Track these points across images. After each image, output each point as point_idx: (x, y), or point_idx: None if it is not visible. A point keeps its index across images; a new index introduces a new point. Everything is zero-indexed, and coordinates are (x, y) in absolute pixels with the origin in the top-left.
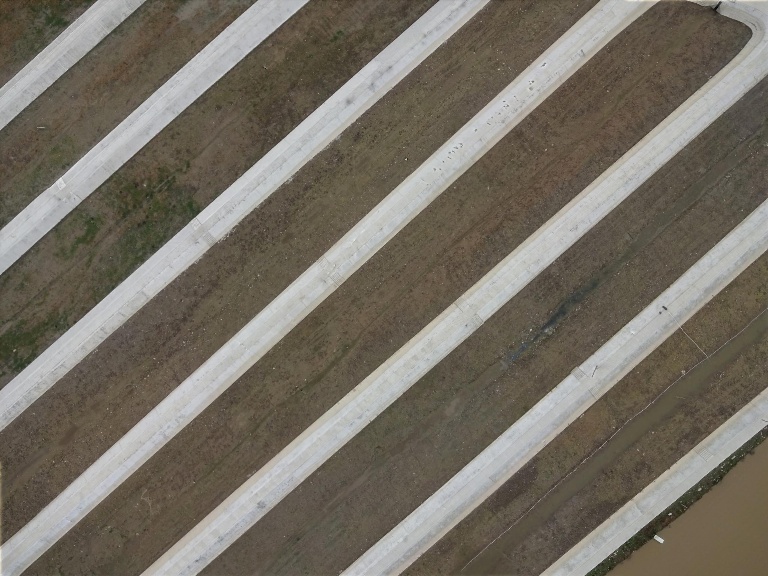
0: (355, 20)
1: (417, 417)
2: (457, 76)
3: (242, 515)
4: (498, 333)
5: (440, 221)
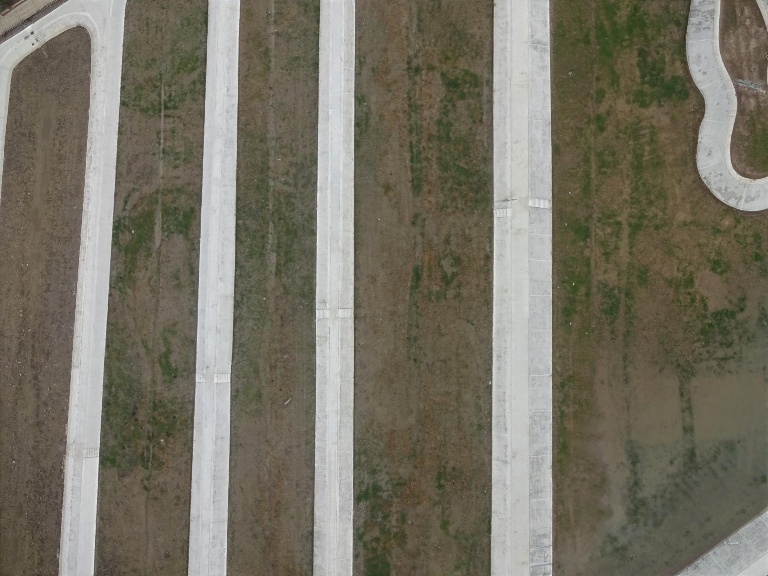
0: None
1: None
2: None
3: None
4: None
5: None
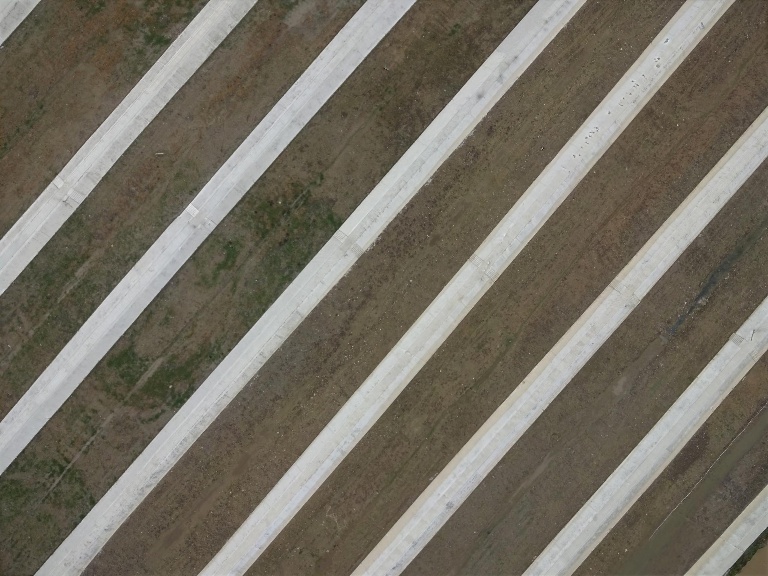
0: (470, 11)
1: (588, 400)
2: (581, 60)
3: (433, 518)
4: (655, 310)
5: (584, 207)
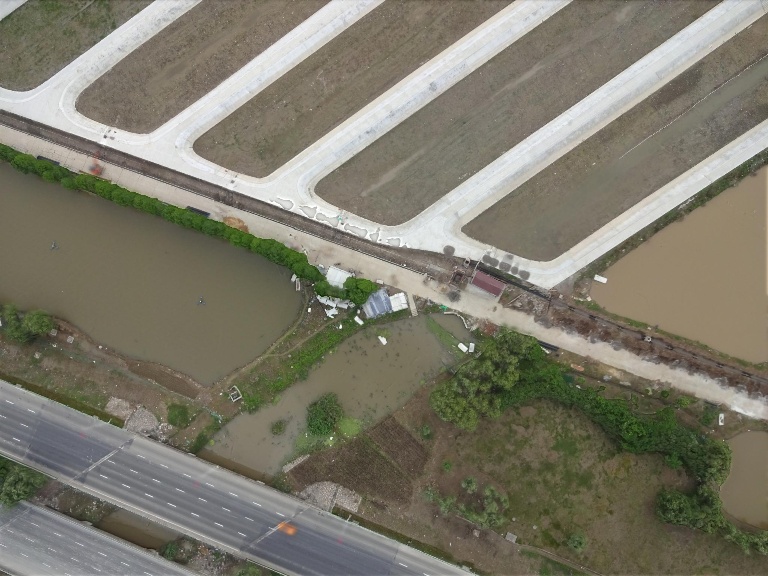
0: None
1: (588, 20)
2: None
3: (415, 93)
4: None
5: None
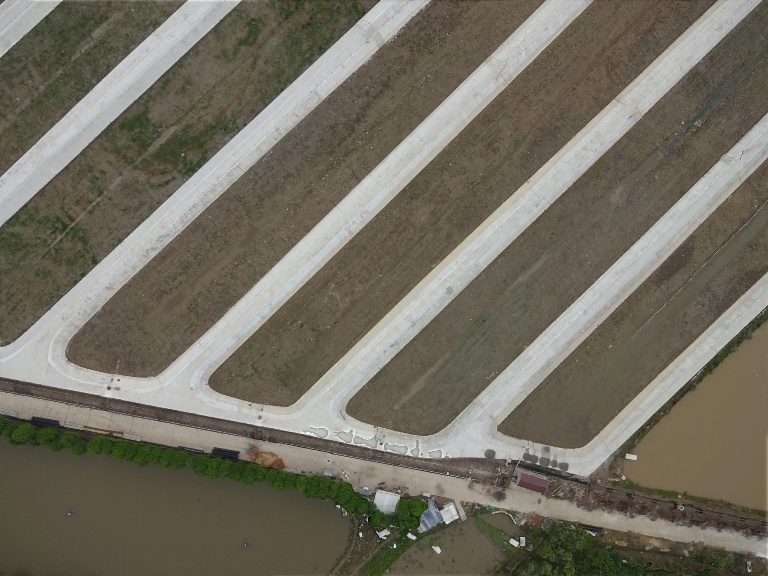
0: None
1: (586, 205)
2: None
3: (433, 300)
4: (655, 126)
5: (598, 23)
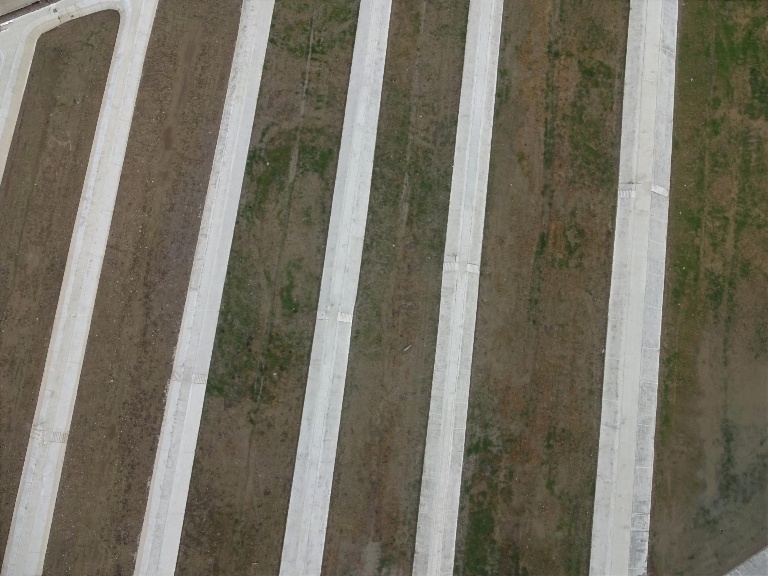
0: None
1: None
2: None
3: None
4: None
5: None
